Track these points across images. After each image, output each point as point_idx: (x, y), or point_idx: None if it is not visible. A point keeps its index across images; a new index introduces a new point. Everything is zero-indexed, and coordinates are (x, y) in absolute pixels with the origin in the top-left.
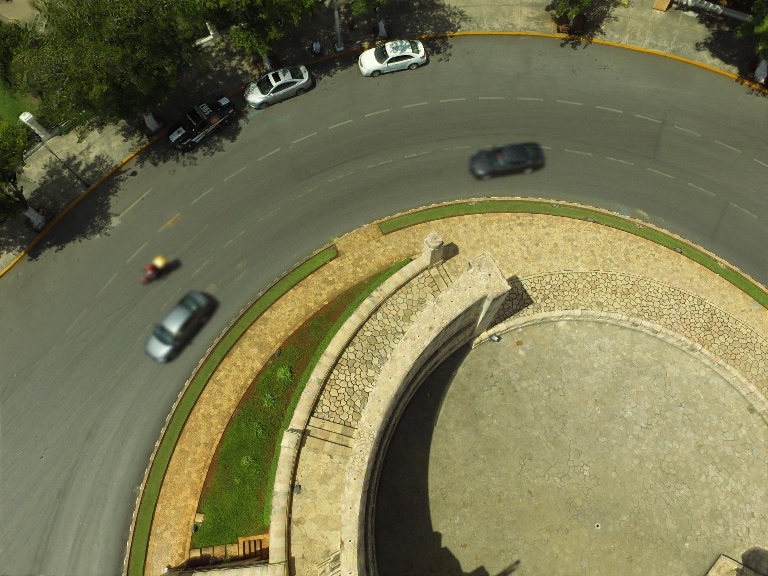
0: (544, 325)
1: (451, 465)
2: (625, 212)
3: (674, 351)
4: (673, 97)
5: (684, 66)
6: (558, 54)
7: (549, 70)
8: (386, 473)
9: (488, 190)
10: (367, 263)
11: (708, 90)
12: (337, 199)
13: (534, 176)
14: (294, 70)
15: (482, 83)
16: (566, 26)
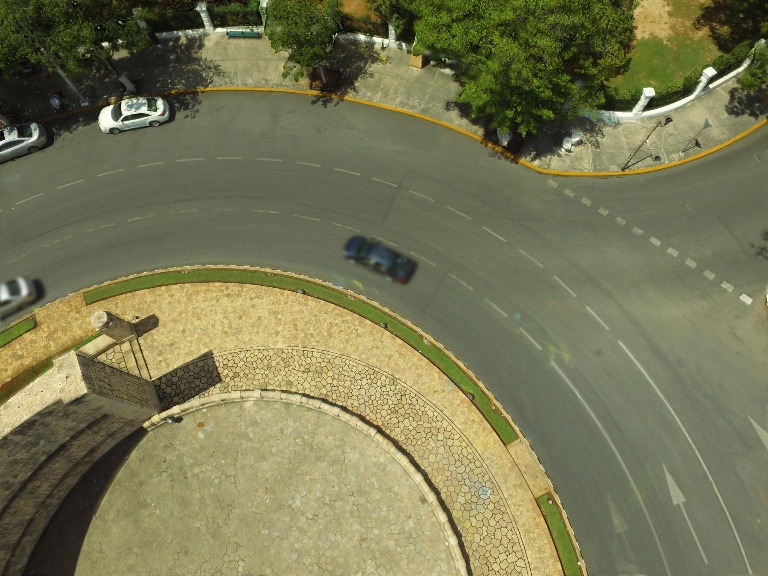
0: (230, 405)
1: (102, 559)
2: (340, 282)
3: (357, 435)
4: (414, 159)
5: (432, 126)
6: (307, 112)
7: (294, 129)
8: (32, 568)
9: (205, 257)
10: (61, 336)
11: (451, 152)
12: (48, 265)
13: (255, 242)
14: (24, 127)
15: (223, 142)
16: (320, 82)
